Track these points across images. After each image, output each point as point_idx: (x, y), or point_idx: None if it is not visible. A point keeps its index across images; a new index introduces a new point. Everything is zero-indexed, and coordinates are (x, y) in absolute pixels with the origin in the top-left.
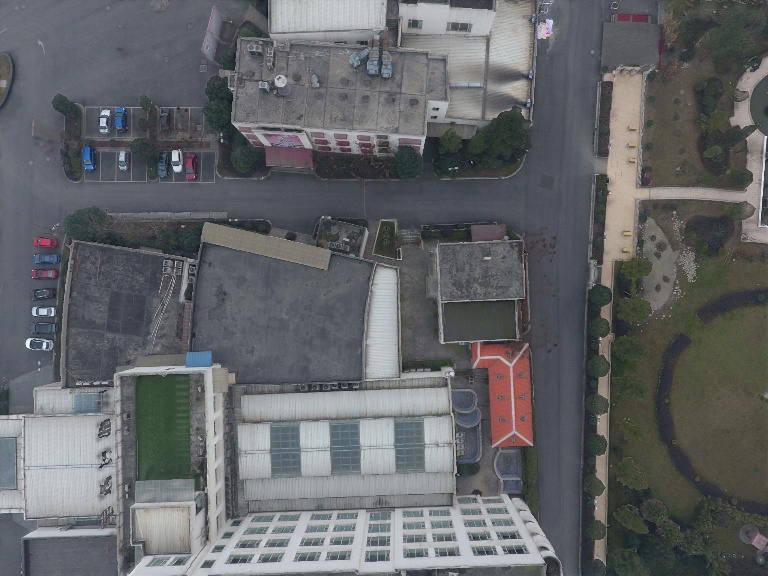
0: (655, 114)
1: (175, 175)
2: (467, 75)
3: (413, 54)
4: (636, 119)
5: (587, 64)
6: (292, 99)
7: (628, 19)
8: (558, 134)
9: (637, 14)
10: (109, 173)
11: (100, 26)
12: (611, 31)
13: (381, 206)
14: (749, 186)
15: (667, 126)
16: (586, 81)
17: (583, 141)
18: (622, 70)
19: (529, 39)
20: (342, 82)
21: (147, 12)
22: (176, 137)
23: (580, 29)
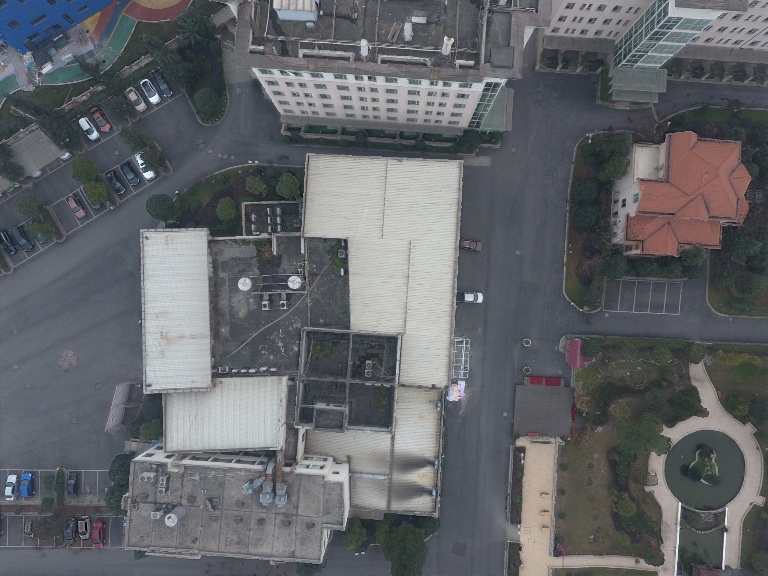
0: (568, 479)
1: (83, 540)
2: (372, 462)
3: (310, 475)
4: (549, 484)
5: (500, 426)
6: (187, 521)
7: (541, 382)
8: (470, 499)
9: (550, 375)
10: (16, 537)
11: (7, 386)
12: (523, 395)
13: (292, 572)
14: (664, 553)
15: (581, 491)
16: (499, 444)
17: (496, 506)
18: (534, 436)
19: (435, 424)
20: (237, 506)
21: (55, 372)
22: (84, 500)
23: (493, 391)
